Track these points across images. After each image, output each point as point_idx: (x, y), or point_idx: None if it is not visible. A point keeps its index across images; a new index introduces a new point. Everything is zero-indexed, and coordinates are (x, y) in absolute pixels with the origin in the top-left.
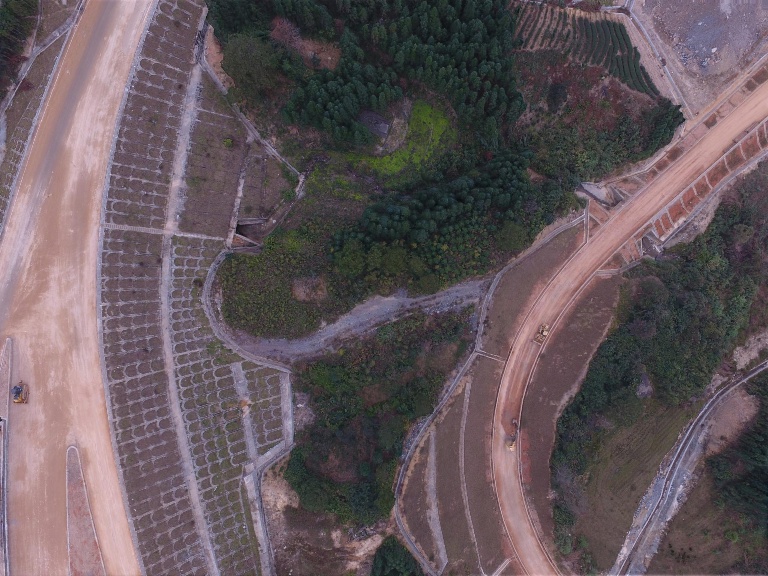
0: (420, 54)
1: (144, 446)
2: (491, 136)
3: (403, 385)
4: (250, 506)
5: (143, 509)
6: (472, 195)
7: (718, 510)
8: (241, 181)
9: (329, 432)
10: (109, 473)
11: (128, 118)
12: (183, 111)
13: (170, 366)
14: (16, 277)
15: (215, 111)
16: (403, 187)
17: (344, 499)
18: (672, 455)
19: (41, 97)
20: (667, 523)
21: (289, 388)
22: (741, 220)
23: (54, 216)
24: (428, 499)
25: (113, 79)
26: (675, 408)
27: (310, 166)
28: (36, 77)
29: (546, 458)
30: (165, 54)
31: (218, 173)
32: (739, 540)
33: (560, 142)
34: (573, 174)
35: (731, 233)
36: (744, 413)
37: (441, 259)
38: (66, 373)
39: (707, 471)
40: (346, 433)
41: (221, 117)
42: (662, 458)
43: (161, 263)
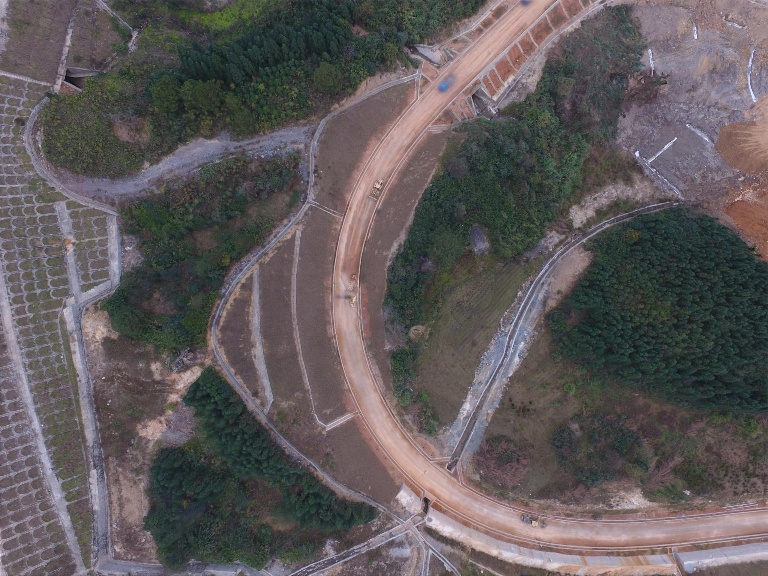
0: None
1: None
2: None
3: (233, 232)
4: (69, 337)
5: None
6: (288, 38)
7: (556, 363)
8: (69, 31)
9: (154, 271)
10: None
11: None
12: None
13: None
14: None
15: None
16: None
17: (161, 329)
18: (514, 313)
19: None
20: (508, 378)
21: (116, 230)
22: (565, 75)
23: None
24: (253, 337)
25: None
26: (513, 264)
27: (144, 23)
28: None
29: (380, 307)
30: None
31: (43, 19)
32: (577, 392)
33: (387, 1)
34: (401, 32)
35: (557, 89)
36: (578, 267)
37: (259, 99)
38: None
39: (545, 326)
40: (170, 271)
41: None
42: (502, 314)
43: None
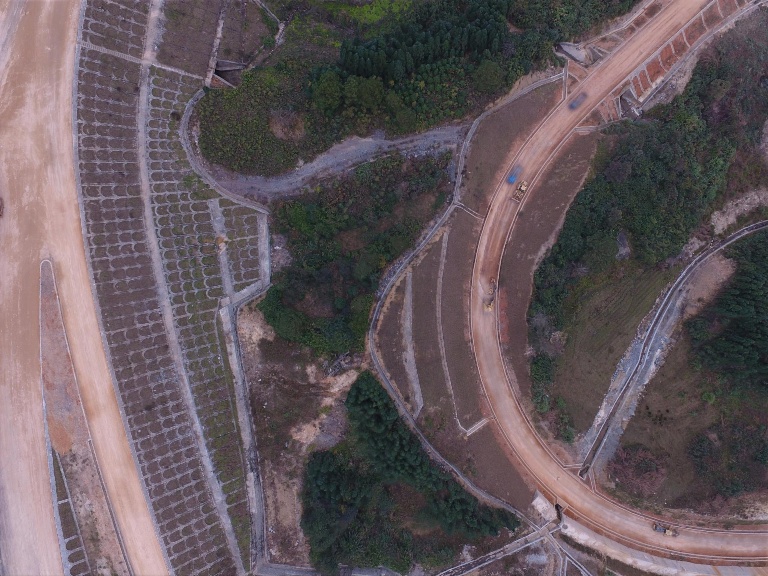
0: None
1: (118, 265)
2: None
3: (381, 233)
4: (225, 338)
5: (116, 325)
6: None
7: (695, 372)
8: (220, 22)
9: (306, 272)
10: (83, 287)
11: None
12: None
13: (146, 193)
14: None
15: None
16: None
17: (319, 331)
18: (650, 320)
19: None
20: (644, 386)
21: (266, 229)
22: (718, 78)
23: (31, 34)
24: (404, 341)
25: None
26: (653, 270)
27: (290, 16)
28: None
29: (523, 312)
30: None
31: (197, 10)
32: (716, 402)
33: None
34: (552, 29)
35: (708, 91)
36: (721, 274)
37: (418, 97)
38: (41, 188)
39: (684, 333)
40: (322, 272)
41: None
42: (640, 321)
43: (138, 92)
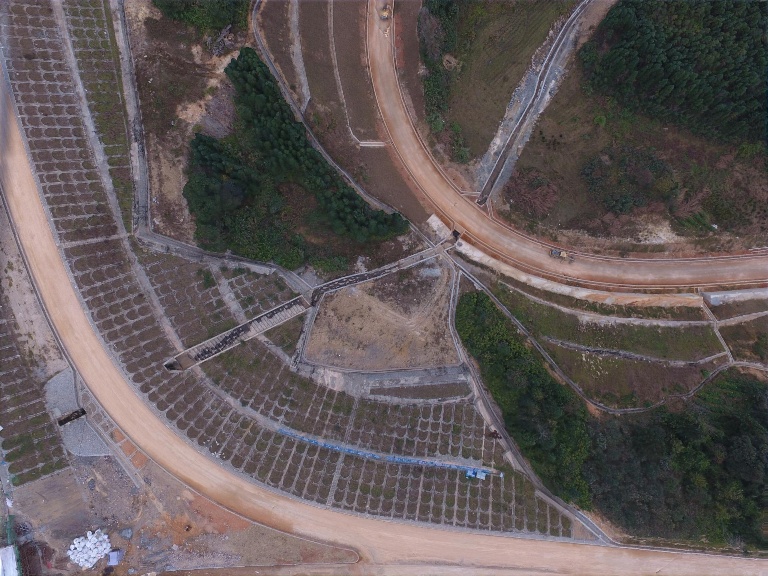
0: None
1: None
2: None
3: None
4: (112, 16)
5: None
6: None
7: (587, 98)
8: None
9: None
10: None
11: None
12: None
13: None
14: None
15: None
16: None
17: (203, 8)
18: (545, 54)
19: None
20: (539, 114)
21: None
22: None
23: None
24: (291, 35)
25: None
26: (545, 1)
27: None
28: None
29: (414, 27)
30: None
31: None
32: (607, 126)
33: None
34: None
35: None
36: (610, 2)
37: None
38: None
39: (576, 61)
40: None
41: None
42: (533, 50)
43: None
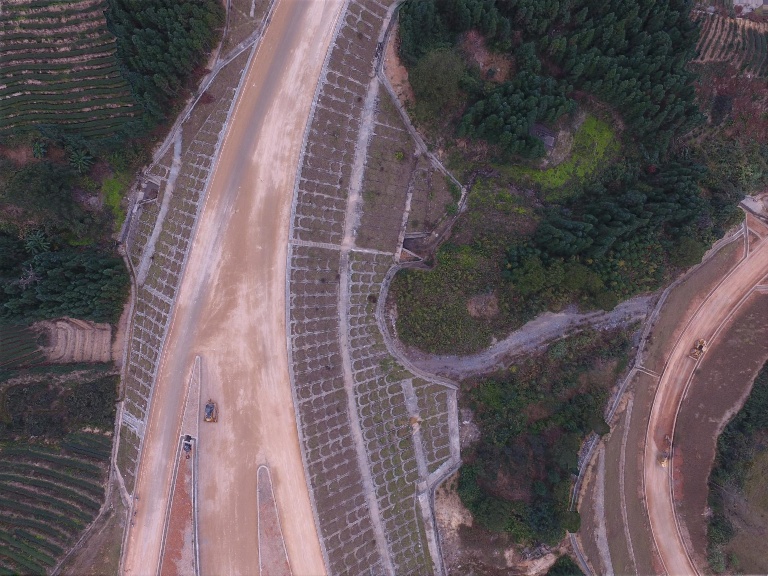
0: (600, 66)
1: (330, 465)
2: (661, 149)
3: (566, 401)
4: (424, 525)
5: (332, 529)
6: (649, 210)
7: None
8: (409, 195)
9: (498, 449)
10: (299, 493)
11: (314, 132)
12: (361, 124)
13: (349, 384)
14: (204, 294)
15: (389, 124)
16: (564, 200)
17: (520, 518)
18: None
19: (227, 111)
20: None
21: (456, 405)
22: None
23: (242, 232)
24: (596, 517)
25: (300, 93)
26: None
27: (471, 179)
28: (218, 90)
29: (704, 475)
30: (348, 67)
31: (390, 187)
32: None
33: (724, 155)
34: (736, 187)
35: None
36: None
37: (616, 275)
38: (255, 391)
39: None
40: (516, 451)
41: (394, 130)
42: None
43: (339, 279)
